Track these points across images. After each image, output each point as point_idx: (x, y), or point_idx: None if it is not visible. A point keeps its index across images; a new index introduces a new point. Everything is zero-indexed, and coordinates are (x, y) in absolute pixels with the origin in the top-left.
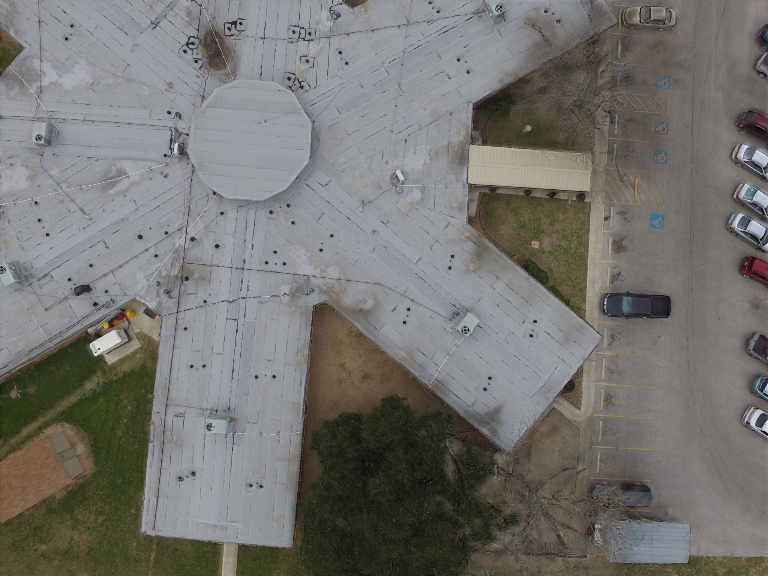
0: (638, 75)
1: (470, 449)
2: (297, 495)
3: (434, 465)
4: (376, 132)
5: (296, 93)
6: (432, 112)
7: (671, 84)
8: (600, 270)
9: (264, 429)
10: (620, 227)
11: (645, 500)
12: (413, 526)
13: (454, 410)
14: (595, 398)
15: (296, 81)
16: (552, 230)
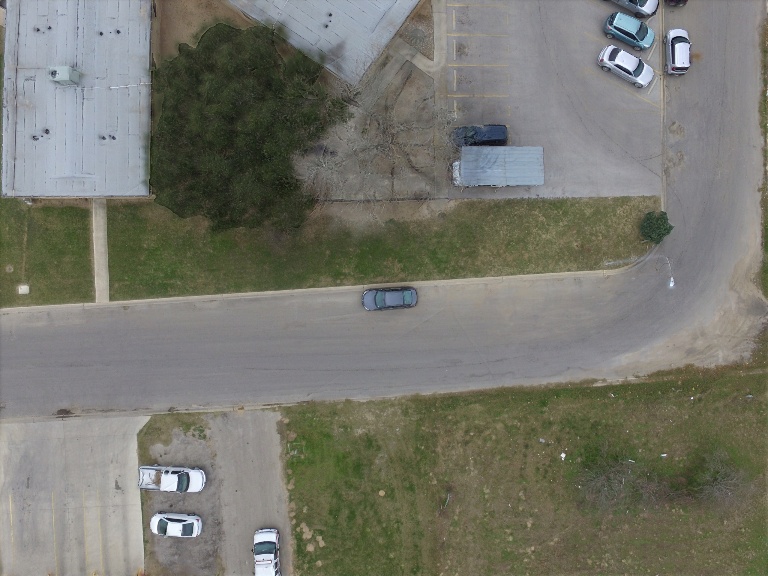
0: None
1: None
2: (150, 145)
3: (258, 55)
4: None
5: None
6: None
7: None
8: None
9: (113, 84)
10: None
11: (499, 133)
12: (237, 105)
13: (298, 51)
14: (447, 48)
15: None
16: None
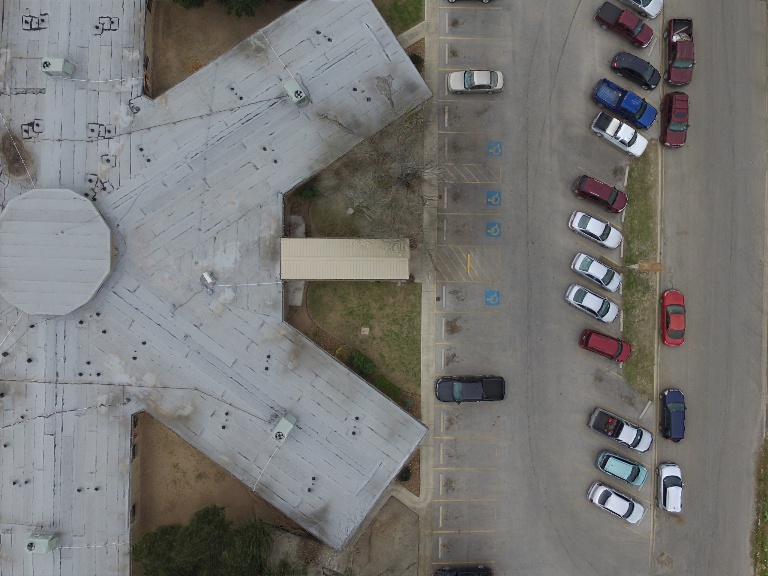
0: (467, 143)
1: (306, 544)
2: None
3: None
4: (183, 232)
5: (99, 195)
6: (240, 206)
7: (503, 150)
8: (434, 353)
9: (91, 541)
10: (453, 306)
11: None
12: None
13: (280, 512)
14: (434, 484)
15: (99, 182)
16: (382, 315)
